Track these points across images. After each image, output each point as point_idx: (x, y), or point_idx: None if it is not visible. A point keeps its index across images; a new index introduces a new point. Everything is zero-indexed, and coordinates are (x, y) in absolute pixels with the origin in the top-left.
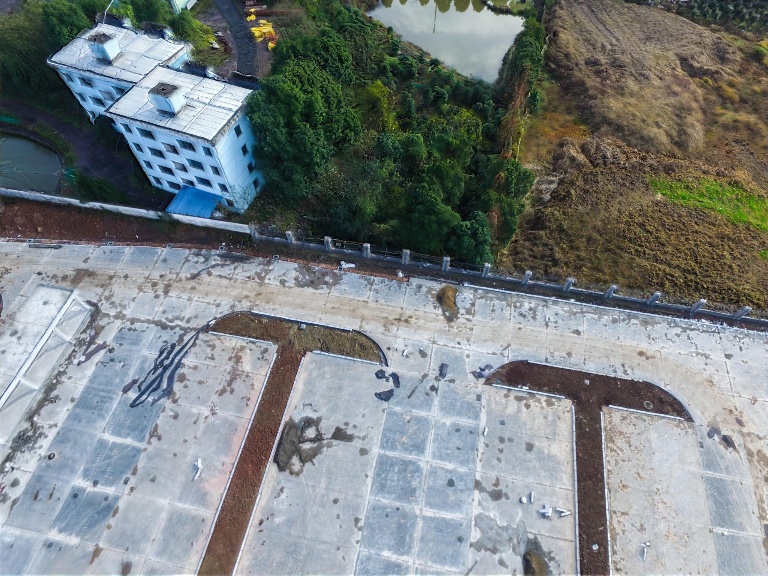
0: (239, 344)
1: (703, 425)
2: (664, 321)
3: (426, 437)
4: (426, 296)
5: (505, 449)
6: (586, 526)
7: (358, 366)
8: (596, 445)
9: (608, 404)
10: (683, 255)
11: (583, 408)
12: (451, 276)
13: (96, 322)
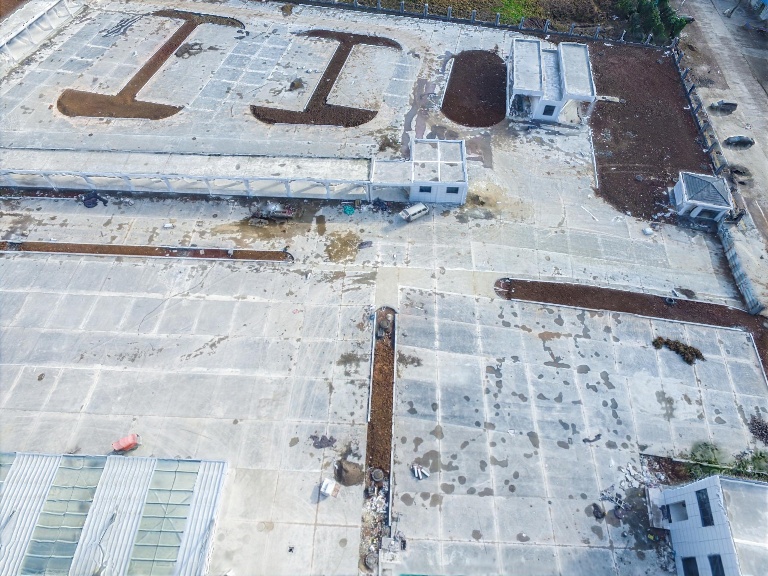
0: (165, 19)
1: (407, 51)
2: (407, 19)
3: (257, 50)
4: (275, 7)
5: (297, 54)
6: (327, 75)
7: (228, 28)
8: (345, 54)
9: (359, 43)
10: (443, 8)
11: (345, 43)
12: (292, 0)
13: (86, 11)
